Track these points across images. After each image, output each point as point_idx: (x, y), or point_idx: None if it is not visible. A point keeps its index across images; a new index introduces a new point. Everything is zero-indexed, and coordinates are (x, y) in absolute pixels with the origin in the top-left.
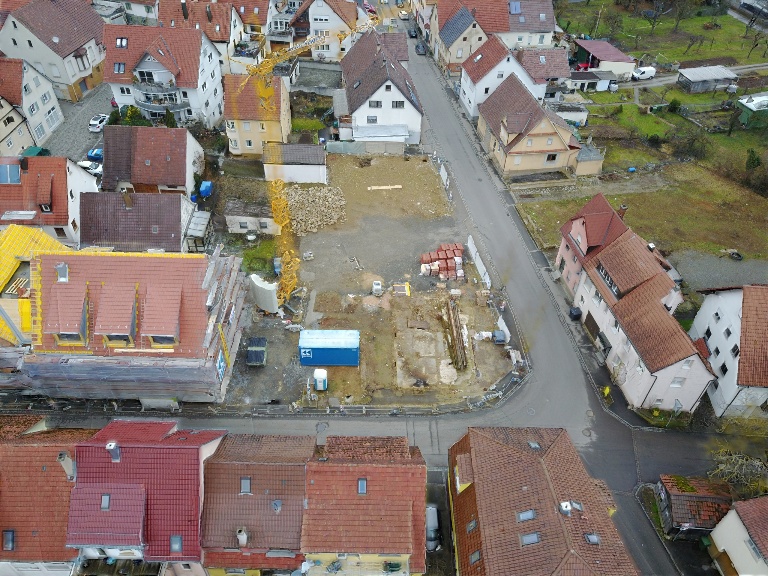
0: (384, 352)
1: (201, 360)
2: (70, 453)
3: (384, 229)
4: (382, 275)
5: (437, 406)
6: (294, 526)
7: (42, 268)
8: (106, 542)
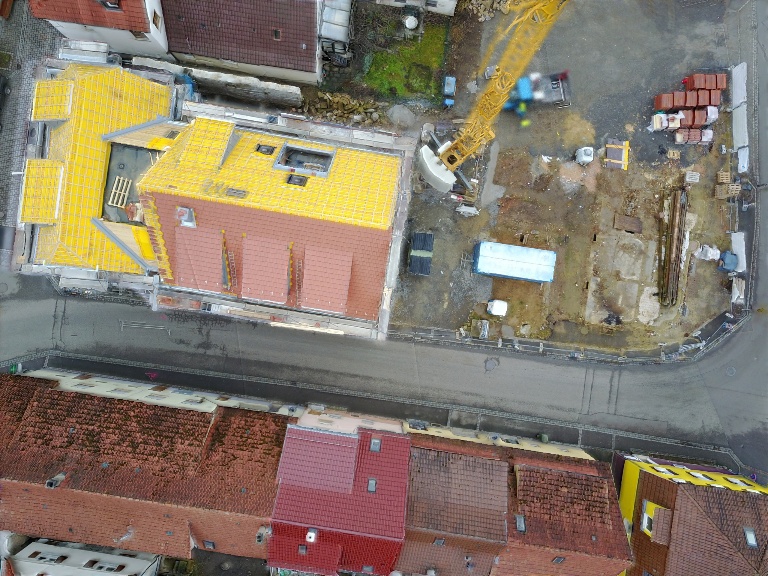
0: (576, 264)
1: (371, 326)
2: (265, 523)
3: (612, 18)
4: (594, 122)
5: (625, 352)
6: (481, 571)
7: (158, 207)
8: (305, 570)
